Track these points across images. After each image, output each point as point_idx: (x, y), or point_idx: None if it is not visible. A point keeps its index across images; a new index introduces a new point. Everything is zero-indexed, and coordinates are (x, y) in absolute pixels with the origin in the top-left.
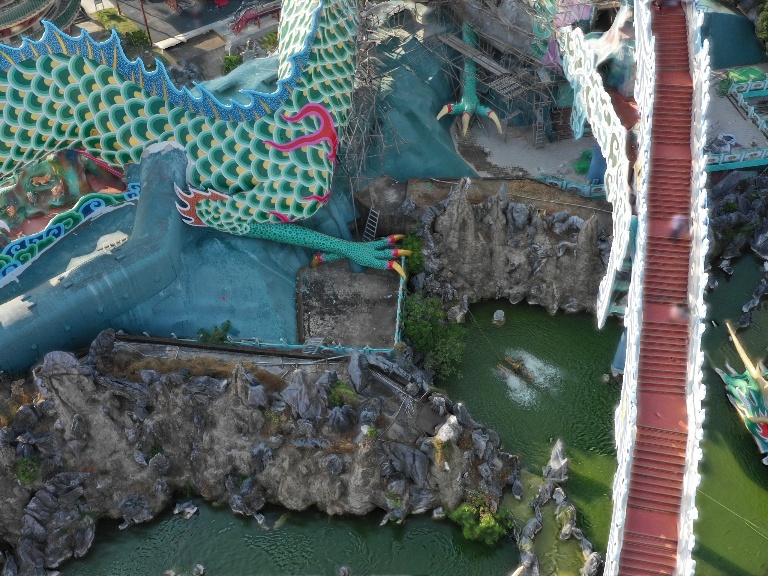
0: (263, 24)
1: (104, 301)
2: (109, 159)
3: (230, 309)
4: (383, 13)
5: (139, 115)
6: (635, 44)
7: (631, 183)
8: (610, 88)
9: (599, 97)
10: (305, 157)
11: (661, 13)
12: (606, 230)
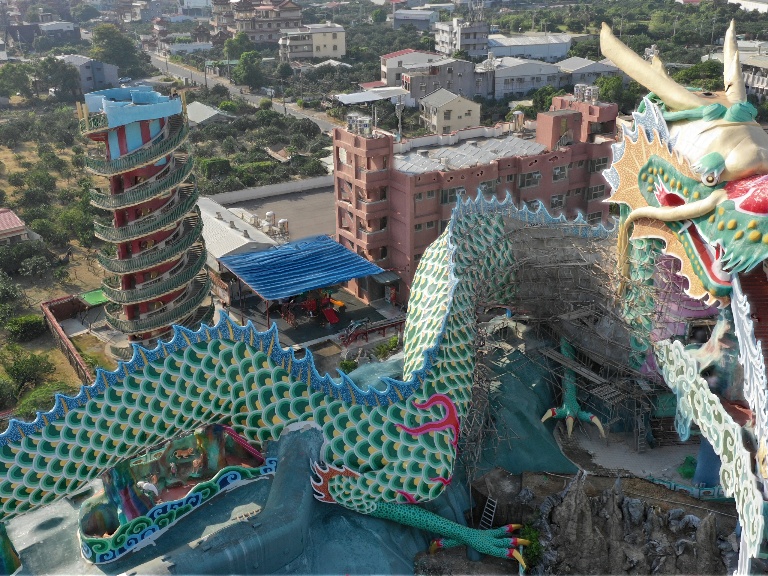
0: (370, 339)
1: (236, 568)
2: (250, 436)
3: None
4: (486, 329)
5: (284, 396)
6: None
7: (755, 472)
8: (714, 392)
9: (706, 399)
10: (432, 441)
11: (761, 324)
12: (723, 530)
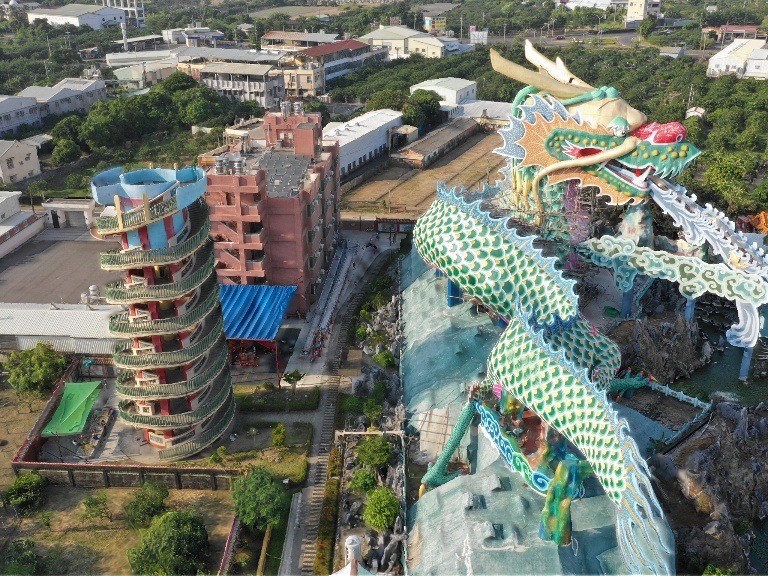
0: (324, 344)
1: None
2: None
3: (643, 432)
4: (445, 288)
5: None
6: (675, 219)
7: None
8: None
9: (653, 256)
10: None
11: None
12: None
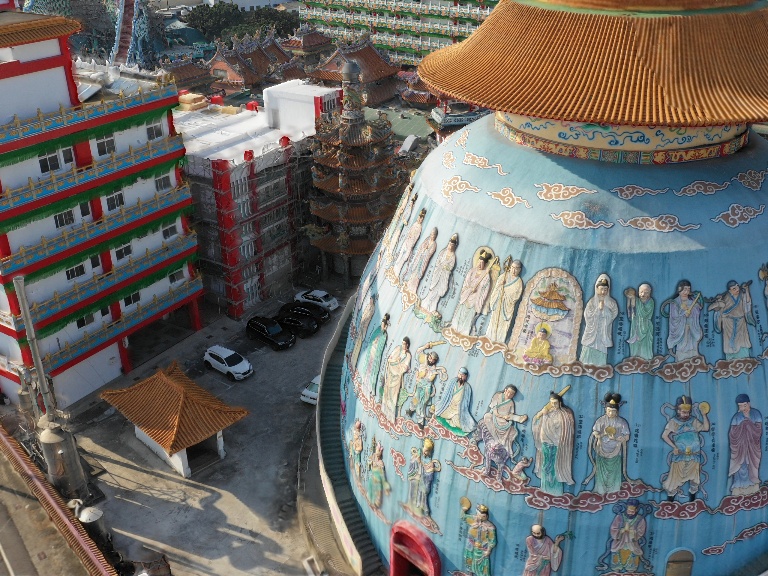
0: None
1: None
2: None
3: None
4: None
5: None
6: None
7: None
8: None
9: None
10: None
11: None
12: None
